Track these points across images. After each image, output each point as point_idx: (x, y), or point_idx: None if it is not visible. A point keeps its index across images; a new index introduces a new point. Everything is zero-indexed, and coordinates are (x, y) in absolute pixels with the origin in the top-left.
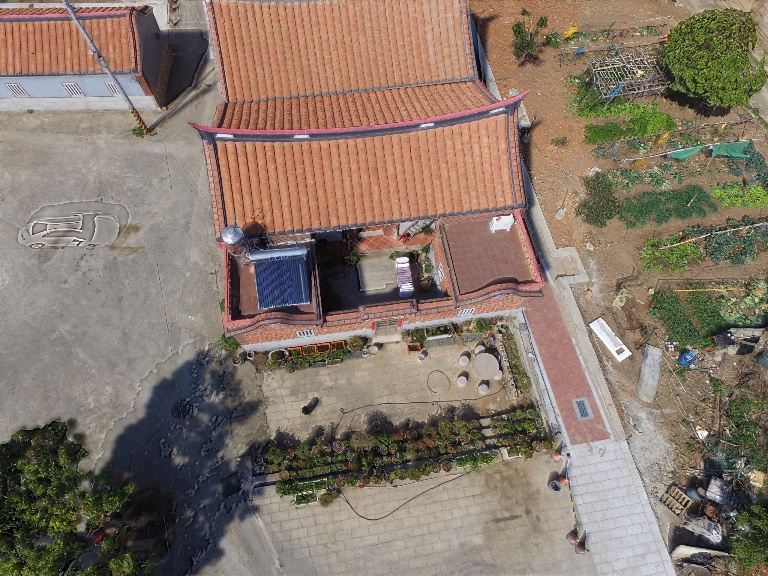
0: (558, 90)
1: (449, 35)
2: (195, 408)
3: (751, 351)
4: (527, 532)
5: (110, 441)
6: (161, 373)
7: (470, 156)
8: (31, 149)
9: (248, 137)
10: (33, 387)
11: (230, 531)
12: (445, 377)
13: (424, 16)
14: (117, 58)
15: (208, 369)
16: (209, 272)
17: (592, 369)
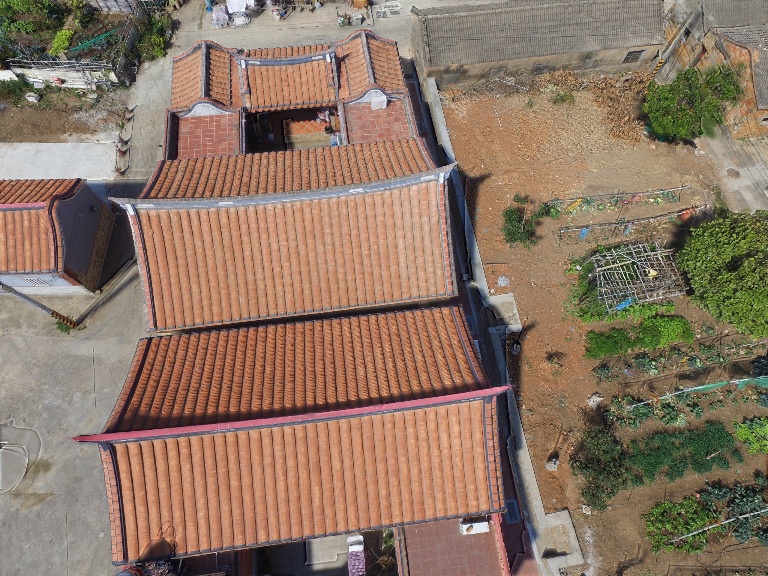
0: (556, 279)
1: (424, 242)
2: None
3: None
4: None
5: None
6: None
7: (436, 448)
8: None
9: (155, 437)
10: None
11: None
12: None
13: (394, 220)
14: (34, 256)
15: None
16: None
17: None
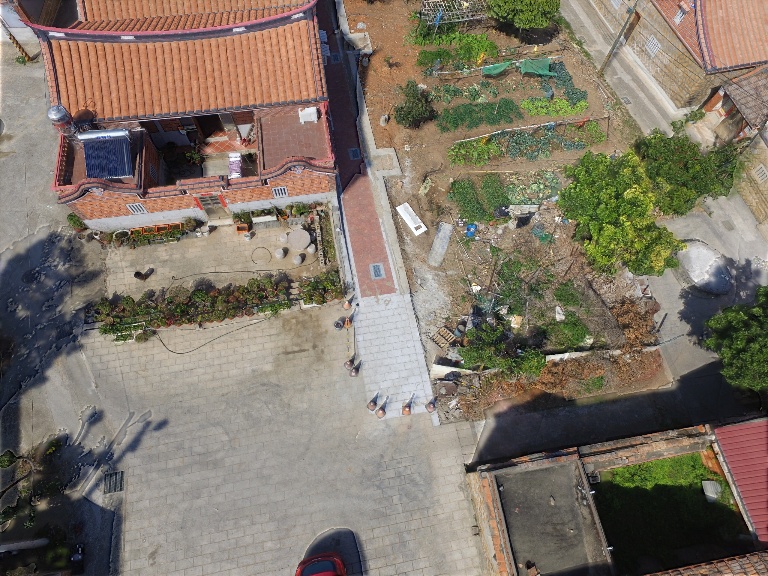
0: (401, 24)
1: None
2: (43, 275)
3: (526, 224)
4: (311, 361)
5: None
6: (17, 249)
7: (278, 56)
8: None
9: (79, 36)
10: None
11: (57, 364)
12: (268, 252)
13: None
14: None
15: (58, 246)
16: None
17: (390, 241)
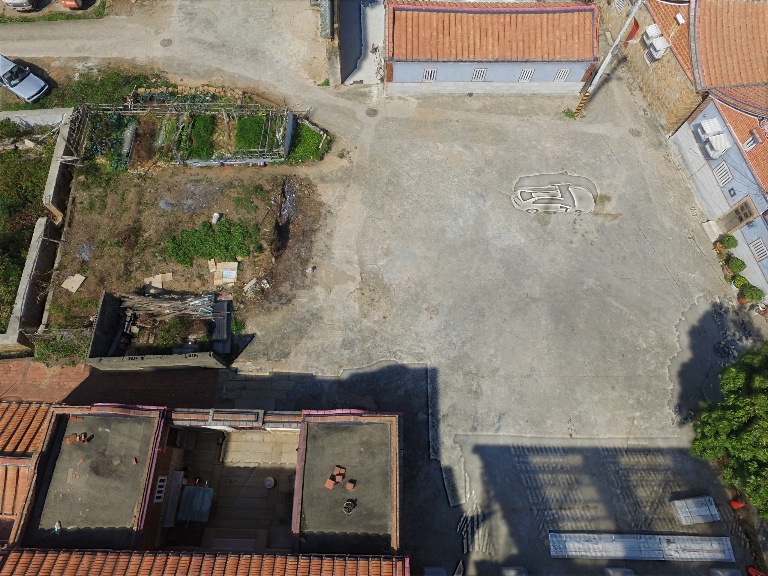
0: None
1: None
2: (733, 350)
3: None
4: None
5: (674, 375)
6: (689, 320)
7: None
8: (486, 127)
9: None
10: (589, 329)
11: None
12: None
13: None
14: (581, 47)
15: (728, 318)
16: (687, 237)
17: None
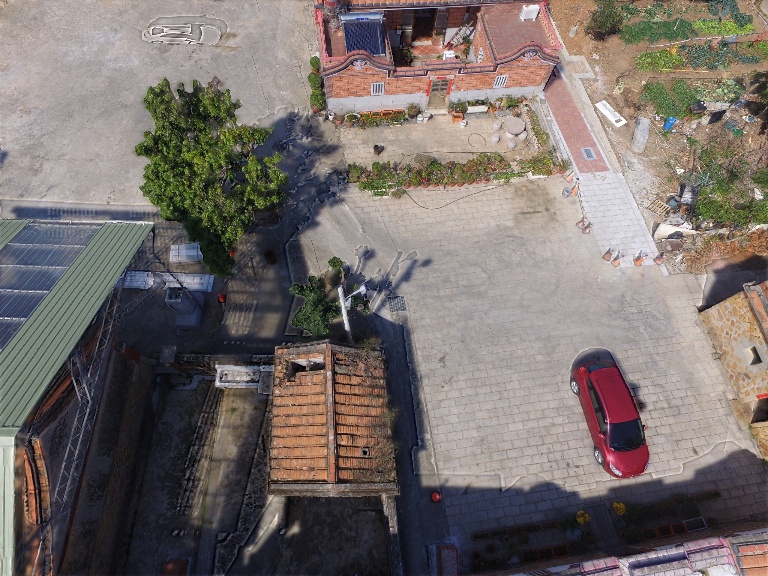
0: None
1: None
2: (290, 146)
3: (719, 119)
4: (546, 220)
5: None
6: (262, 125)
7: None
8: None
9: None
10: None
11: (324, 213)
12: (482, 138)
13: None
14: None
15: (298, 123)
16: (294, 65)
17: (596, 129)
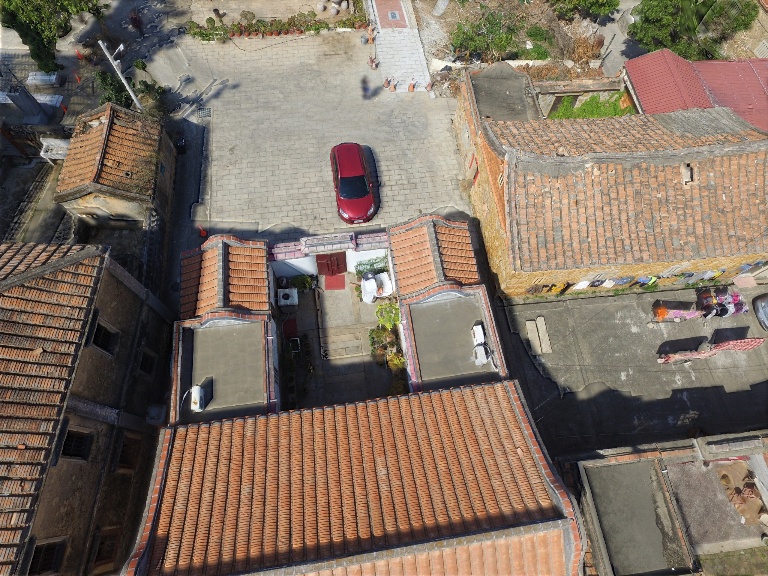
0: None
1: None
2: (146, 10)
3: None
4: (343, 60)
5: (90, 21)
6: None
7: None
8: None
9: None
10: None
11: (161, 53)
12: (311, 8)
13: None
14: None
15: None
16: None
17: None
